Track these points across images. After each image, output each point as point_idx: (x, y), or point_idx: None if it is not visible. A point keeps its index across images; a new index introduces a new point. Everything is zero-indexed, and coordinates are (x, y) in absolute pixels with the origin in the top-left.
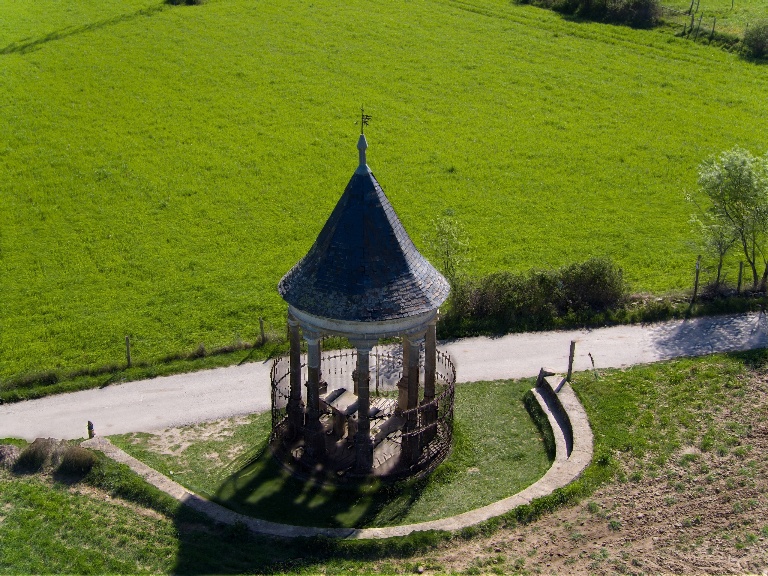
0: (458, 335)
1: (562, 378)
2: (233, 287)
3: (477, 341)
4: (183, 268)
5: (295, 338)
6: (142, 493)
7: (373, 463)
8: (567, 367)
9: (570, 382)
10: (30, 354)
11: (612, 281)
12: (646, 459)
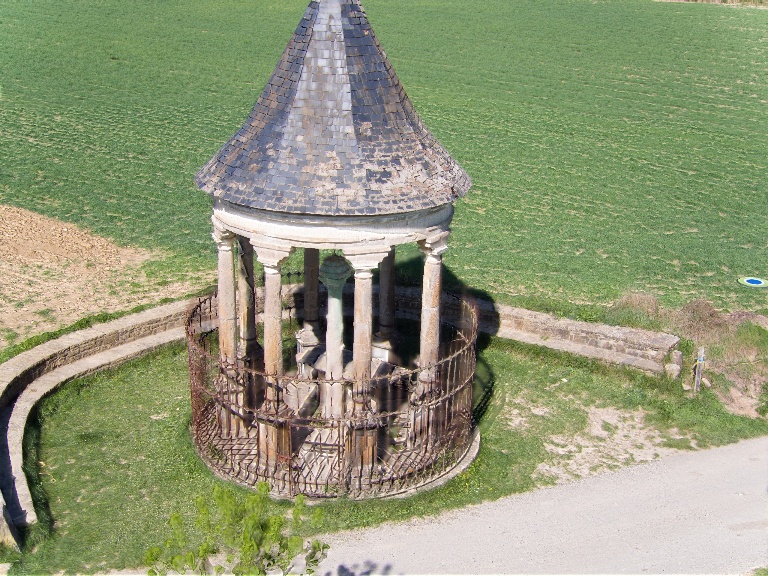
0: None
1: None
2: None
3: None
4: None
5: None
6: None
7: (300, 374)
8: None
9: None
10: None
11: None
12: None
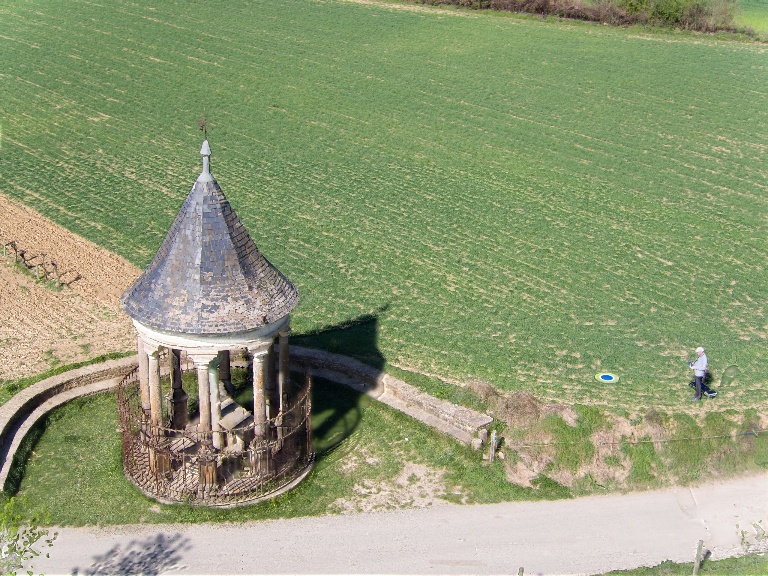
0: None
1: None
2: None
3: None
4: None
5: None
6: None
7: None
8: None
9: None
10: None
11: None
12: None
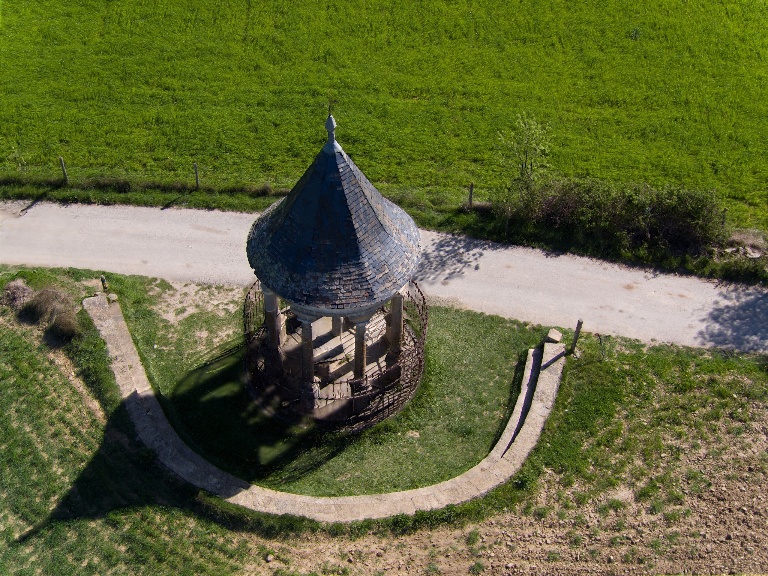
0: (514, 241)
1: (561, 350)
2: (345, 101)
3: (529, 255)
4: (318, 56)
5: None
6: (97, 382)
7: (318, 403)
8: (593, 324)
9: (572, 354)
10: (127, 144)
11: (710, 221)
12: (570, 491)
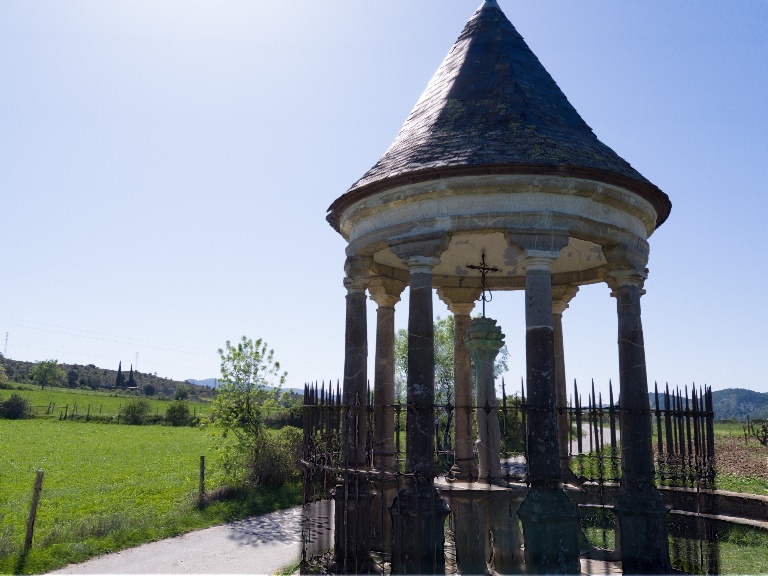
0: (299, 501)
1: None
2: None
3: (329, 502)
4: None
5: (430, 305)
6: None
7: None
8: None
9: None
10: None
11: None
12: None
